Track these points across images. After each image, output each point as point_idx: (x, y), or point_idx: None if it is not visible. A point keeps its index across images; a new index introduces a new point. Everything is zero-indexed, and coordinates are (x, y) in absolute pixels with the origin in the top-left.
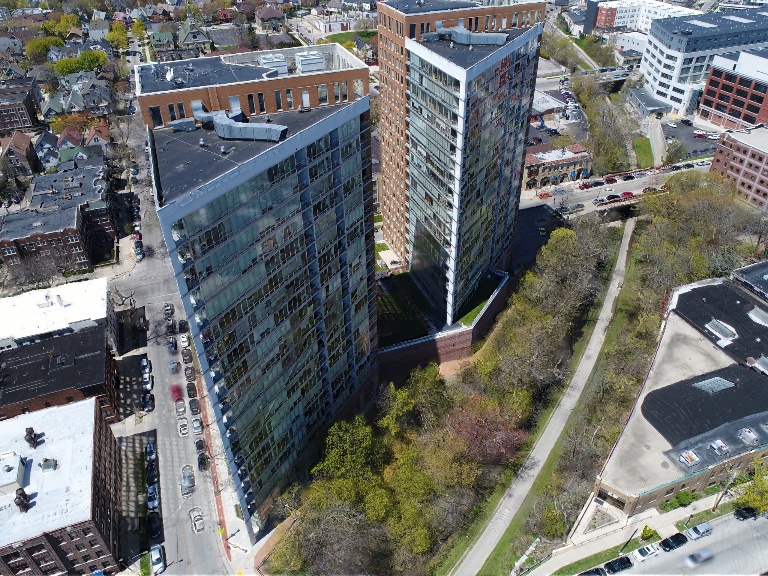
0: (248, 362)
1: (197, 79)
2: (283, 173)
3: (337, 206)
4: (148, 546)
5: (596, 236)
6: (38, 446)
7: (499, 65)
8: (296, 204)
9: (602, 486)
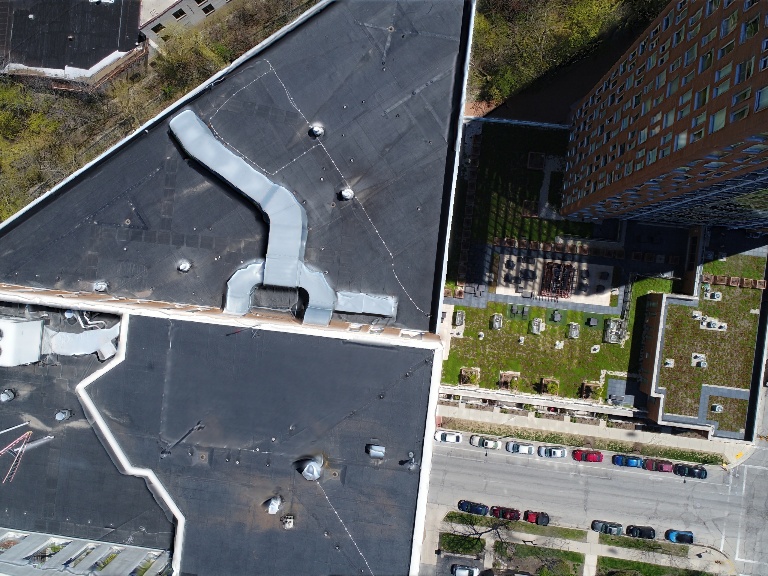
0: None
1: None
2: None
3: None
4: None
5: None
6: None
7: None
8: None
9: None
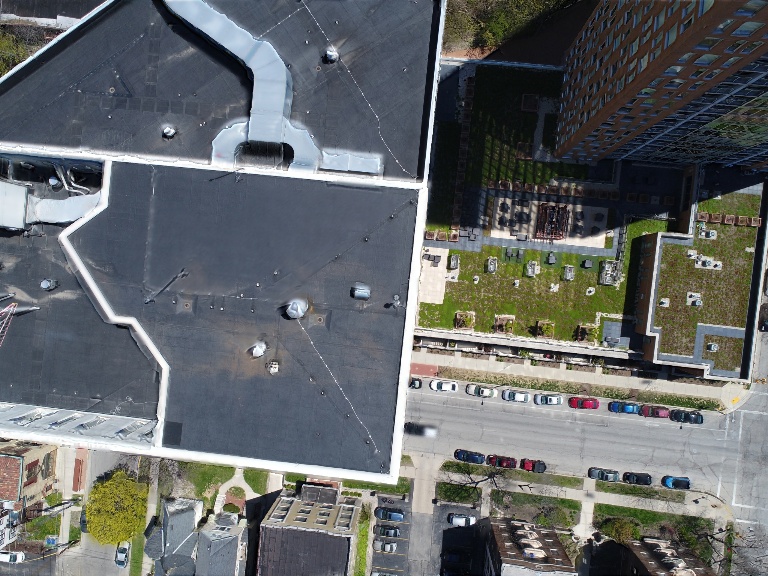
0: None
1: None
2: None
3: None
4: None
5: None
6: None
7: None
8: None
9: None
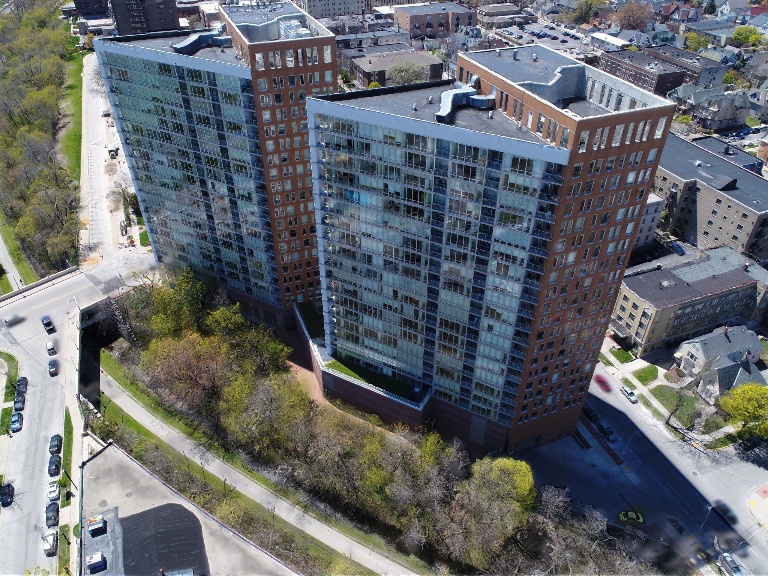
0: None
1: None
2: (167, 72)
3: (220, 132)
4: None
5: None
6: None
7: (399, 136)
8: (180, 101)
9: None
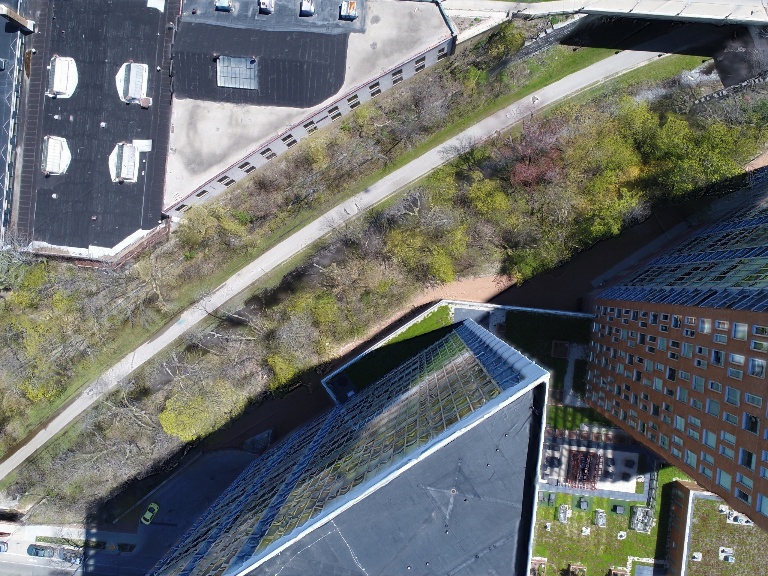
0: None
1: None
2: None
3: None
4: None
5: None
6: None
7: None
8: None
9: None
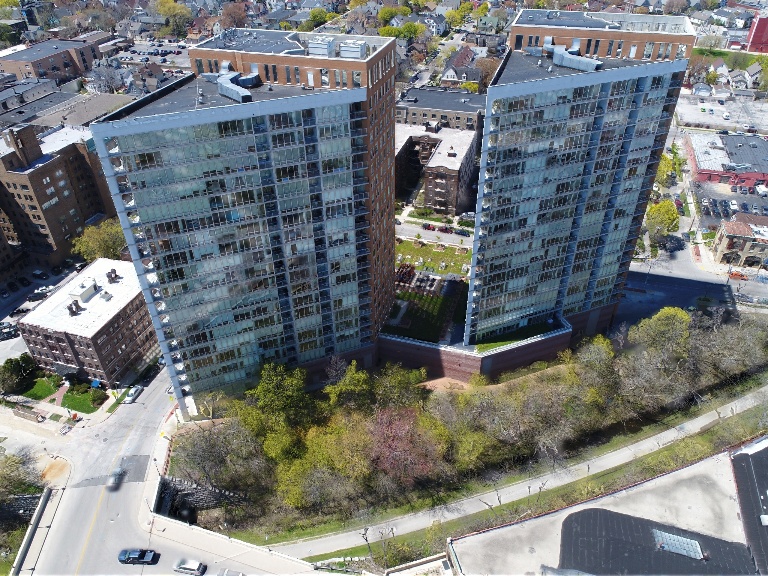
0: (186, 271)
1: (246, 45)
2: (236, 131)
3: (312, 178)
4: (136, 384)
5: (765, 344)
6: (113, 283)
7: (569, 93)
8: (253, 161)
9: (449, 550)
